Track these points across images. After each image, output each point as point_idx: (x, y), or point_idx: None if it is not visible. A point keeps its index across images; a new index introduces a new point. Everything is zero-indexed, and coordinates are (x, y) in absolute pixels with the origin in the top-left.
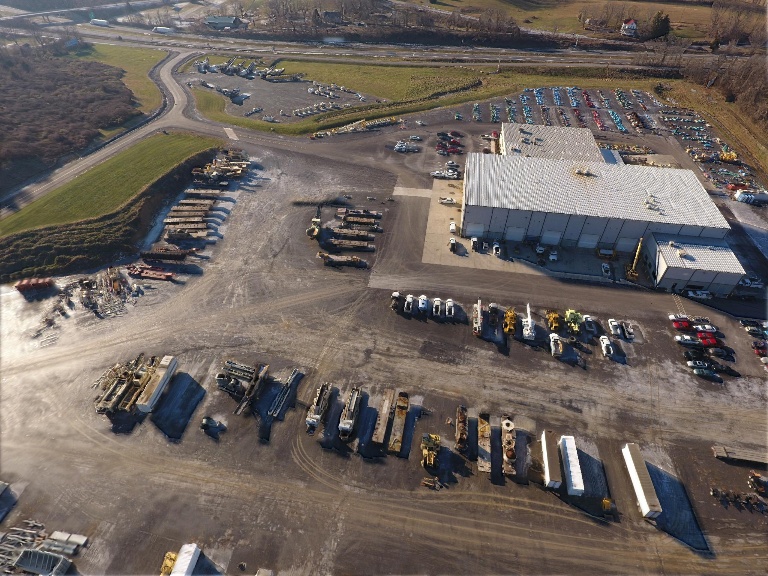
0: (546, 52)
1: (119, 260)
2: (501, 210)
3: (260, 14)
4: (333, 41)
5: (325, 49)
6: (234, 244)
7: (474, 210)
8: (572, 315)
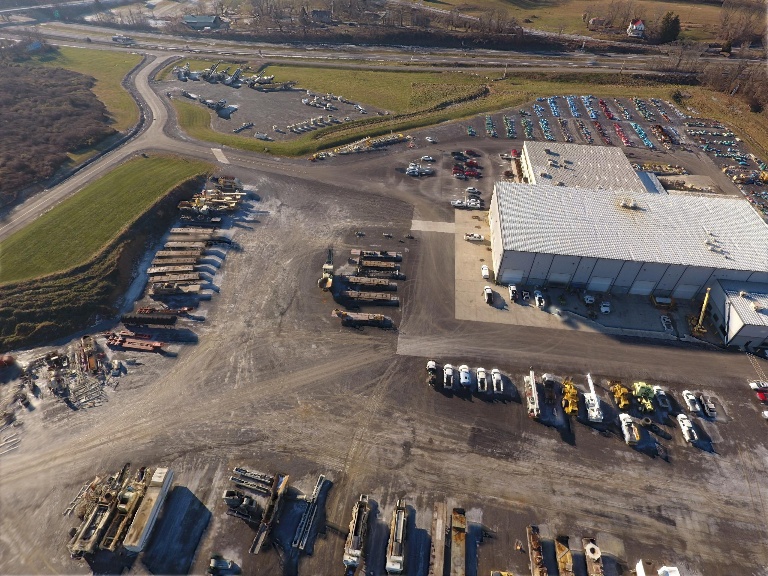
0: (552, 55)
1: (95, 325)
2: (545, 255)
3: (242, 12)
4: (323, 43)
5: (315, 52)
6: (233, 299)
7: (513, 255)
8: (643, 389)
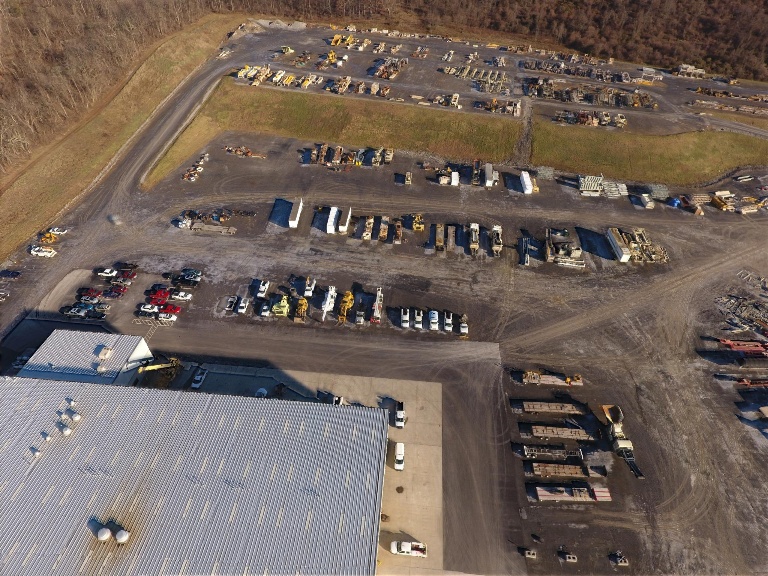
0: None
1: None
2: None
3: None
4: None
5: None
6: (710, 405)
7: None
8: None
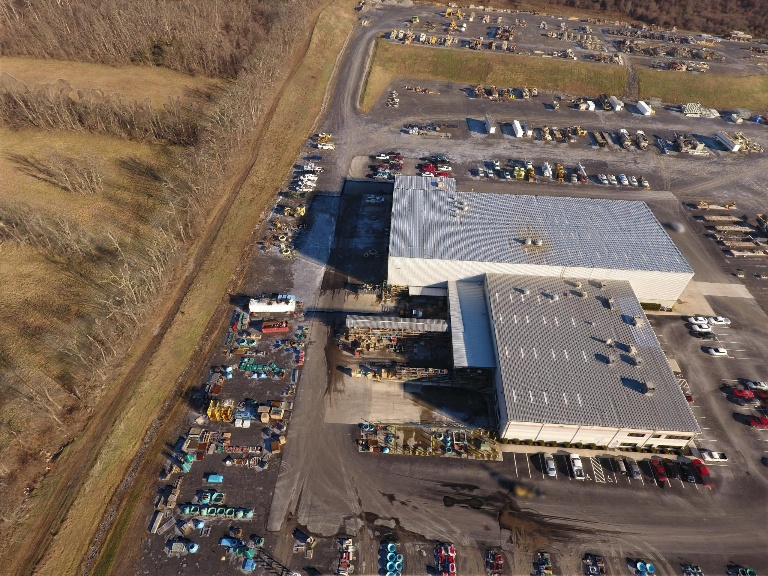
0: None
1: None
2: None
3: None
4: None
5: None
6: None
7: None
8: None
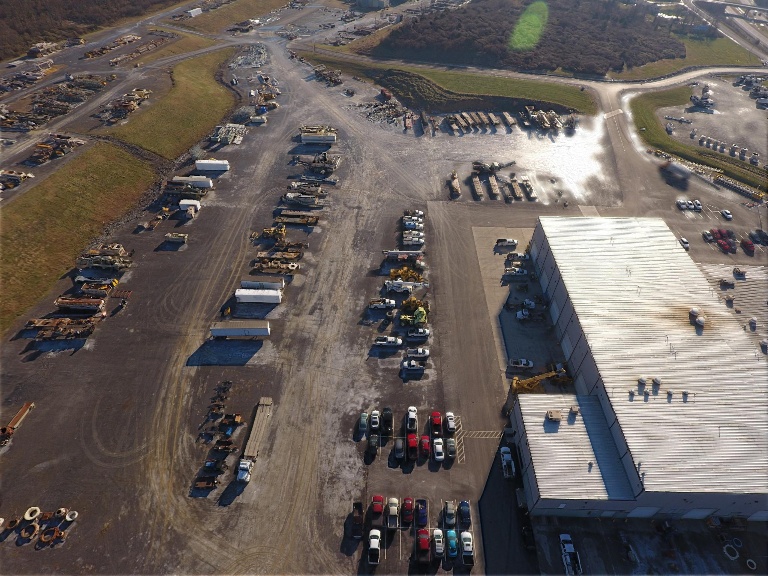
0: None
1: (418, 110)
2: None
3: None
4: None
5: None
6: (454, 142)
7: (539, 228)
8: None
